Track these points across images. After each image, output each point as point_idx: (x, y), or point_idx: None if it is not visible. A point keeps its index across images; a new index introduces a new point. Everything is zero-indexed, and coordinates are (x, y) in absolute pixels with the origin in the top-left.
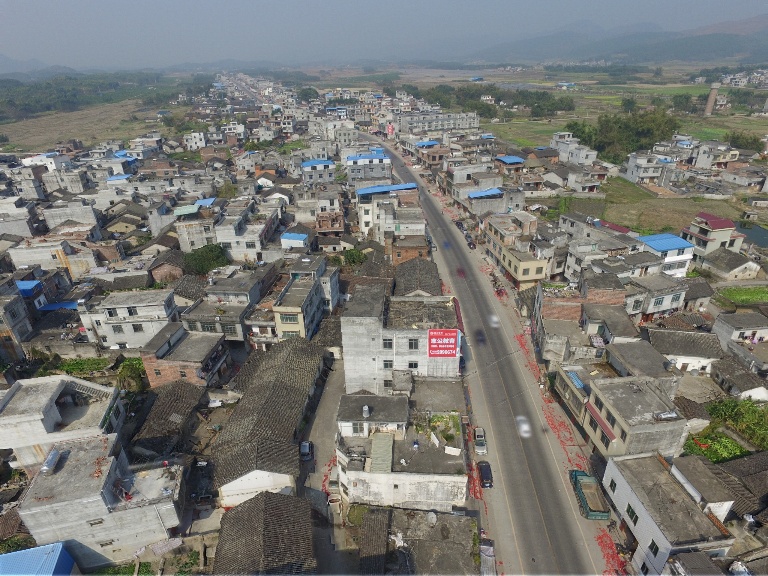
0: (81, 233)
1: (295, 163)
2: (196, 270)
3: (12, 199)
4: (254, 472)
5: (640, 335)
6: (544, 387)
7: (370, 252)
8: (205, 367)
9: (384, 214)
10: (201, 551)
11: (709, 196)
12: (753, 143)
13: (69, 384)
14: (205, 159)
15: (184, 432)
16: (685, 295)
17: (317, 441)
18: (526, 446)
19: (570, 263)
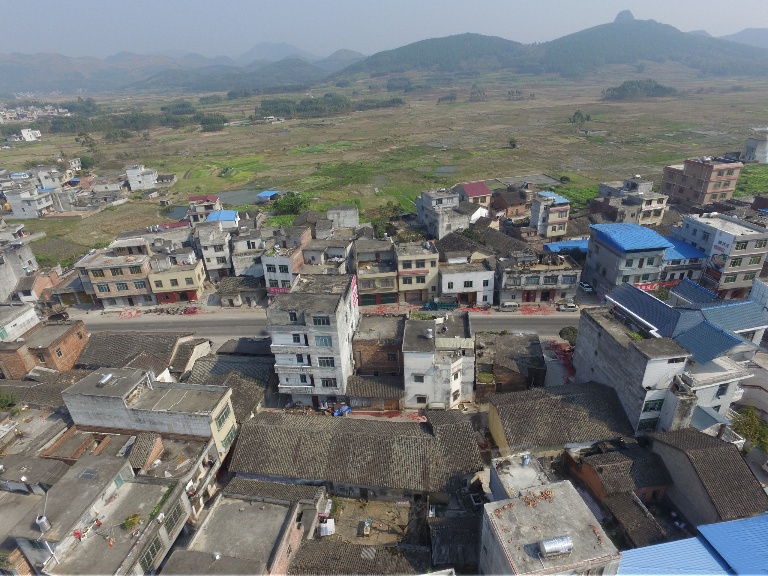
0: None
1: None
2: None
3: None
4: None
5: None
6: None
7: None
8: None
9: None
10: None
11: (116, 203)
12: (56, 164)
13: None
14: None
15: None
16: None
17: None
18: None
19: (209, 255)
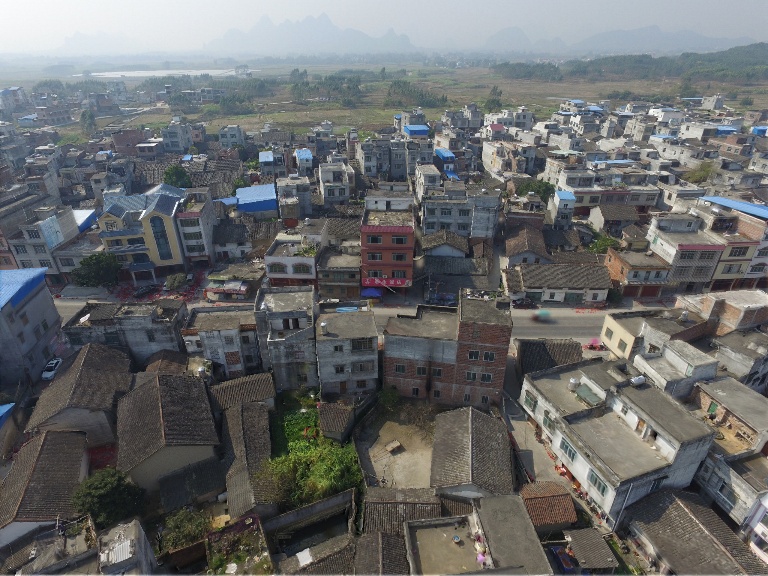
0: None
1: None
2: None
3: None
4: None
5: (388, 334)
6: None
7: None
8: None
9: None
10: None
11: None
12: None
13: (344, 171)
14: None
15: None
16: (656, 534)
17: None
18: None
19: None
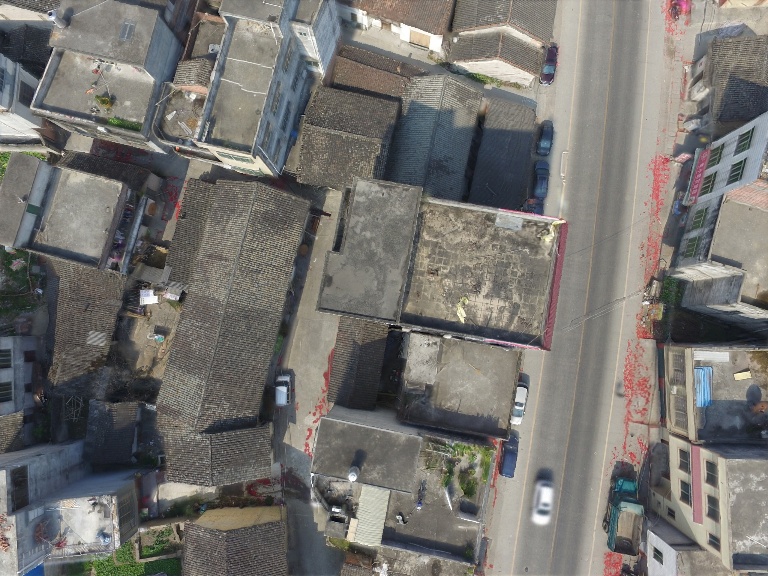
0: None
1: None
2: None
3: None
4: None
5: None
6: (649, 305)
7: None
8: (112, 246)
9: None
10: (174, 530)
11: None
12: None
13: None
14: None
15: (119, 337)
16: None
17: (299, 370)
18: (577, 415)
19: None
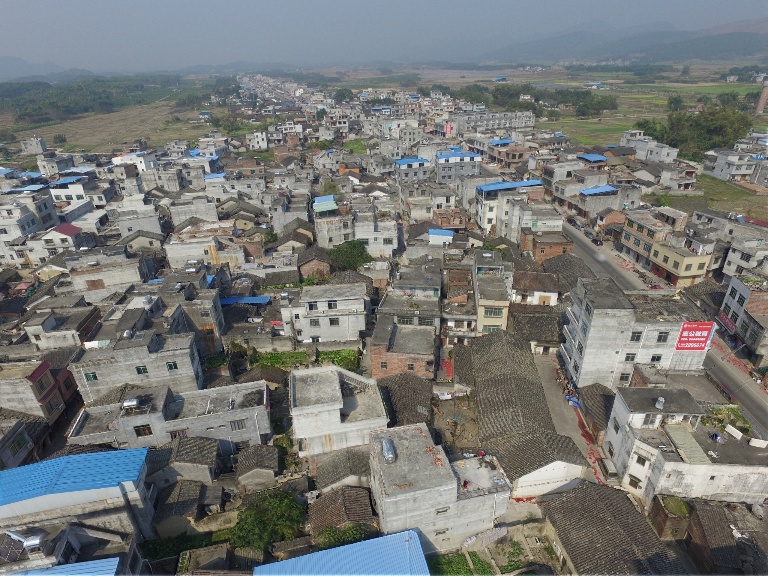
0: (225, 229)
1: (377, 161)
2: (343, 266)
3: (139, 196)
4: (554, 463)
5: None
6: (762, 382)
7: (505, 248)
8: None
9: (518, 210)
10: (525, 541)
11: None
12: None
13: (339, 375)
14: (279, 158)
15: None
16: None
17: (562, 434)
18: None
19: (732, 259)
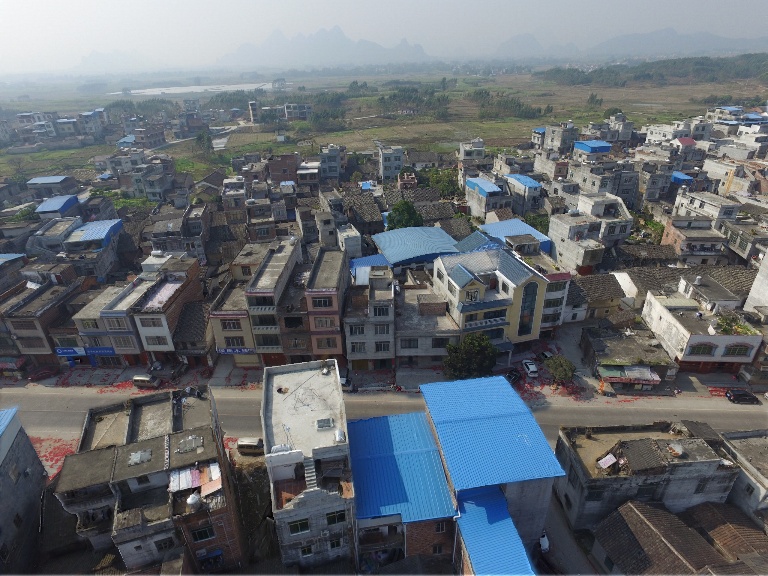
0: (762, 166)
1: None
2: None
3: (759, 135)
4: (626, 274)
5: None
6: None
7: None
8: (692, 247)
9: None
10: None
11: None
12: None
13: None
14: None
15: None
16: None
17: None
18: None
19: None
